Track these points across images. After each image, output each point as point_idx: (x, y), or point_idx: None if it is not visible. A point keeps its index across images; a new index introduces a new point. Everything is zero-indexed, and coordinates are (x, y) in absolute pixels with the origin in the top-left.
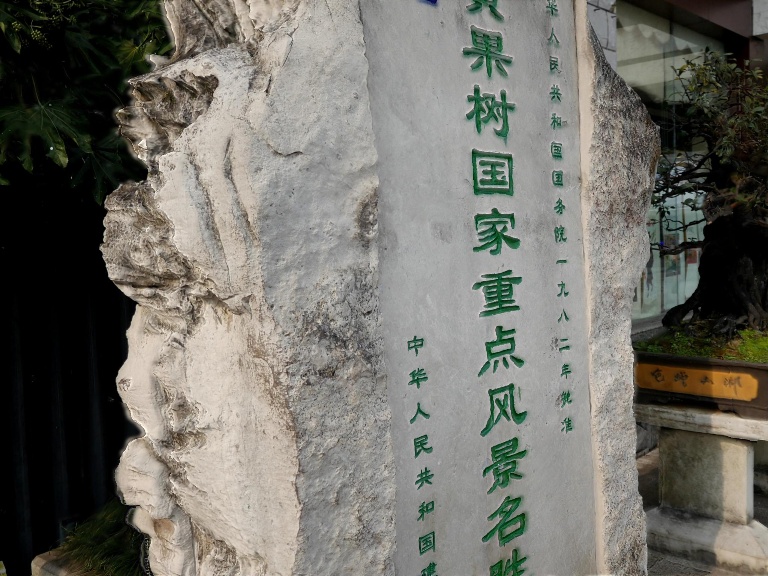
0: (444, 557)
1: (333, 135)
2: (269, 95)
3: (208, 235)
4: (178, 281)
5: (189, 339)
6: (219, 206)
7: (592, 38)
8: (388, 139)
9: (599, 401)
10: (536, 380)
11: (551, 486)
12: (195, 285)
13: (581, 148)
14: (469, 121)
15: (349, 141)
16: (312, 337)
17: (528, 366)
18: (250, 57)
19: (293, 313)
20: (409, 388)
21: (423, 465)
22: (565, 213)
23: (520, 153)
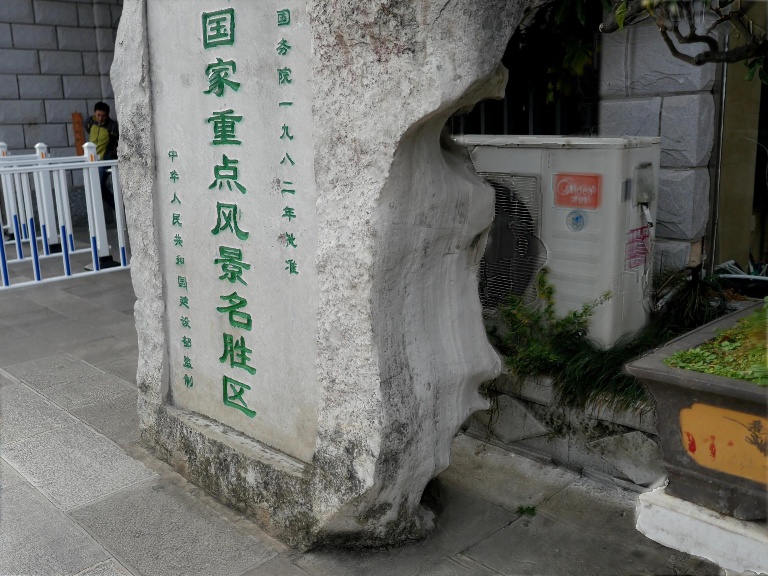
0: (193, 299)
1: None
2: None
3: None
4: None
5: None
6: None
7: None
8: (157, 22)
9: (319, 258)
10: (255, 209)
11: (276, 312)
12: None
13: None
14: None
15: None
16: None
17: (248, 194)
18: None
19: None
20: (171, 181)
21: (177, 232)
22: (292, 53)
23: (240, 4)
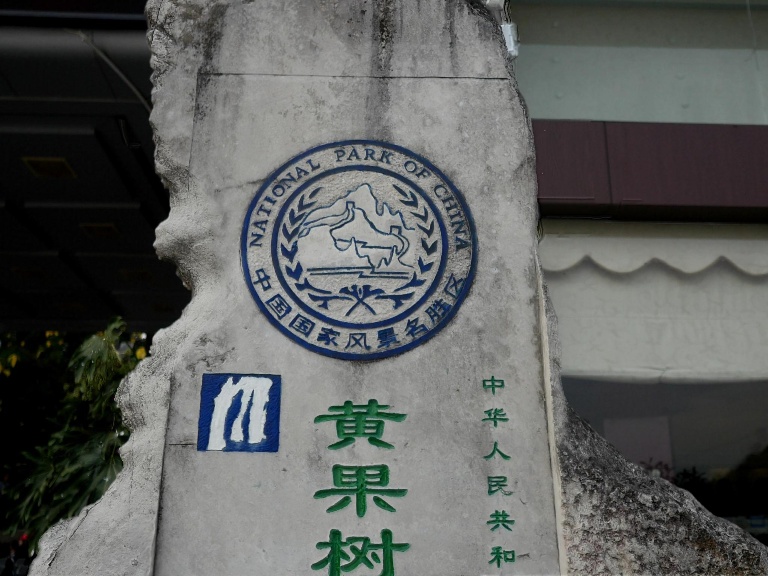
0: None
1: None
2: (50, 568)
3: None
4: None
5: None
6: None
7: (564, 446)
8: None
9: None
10: None
11: None
12: None
13: None
14: (317, 572)
15: None
16: None
17: None
18: None
19: None
20: None
21: None
22: None
23: None
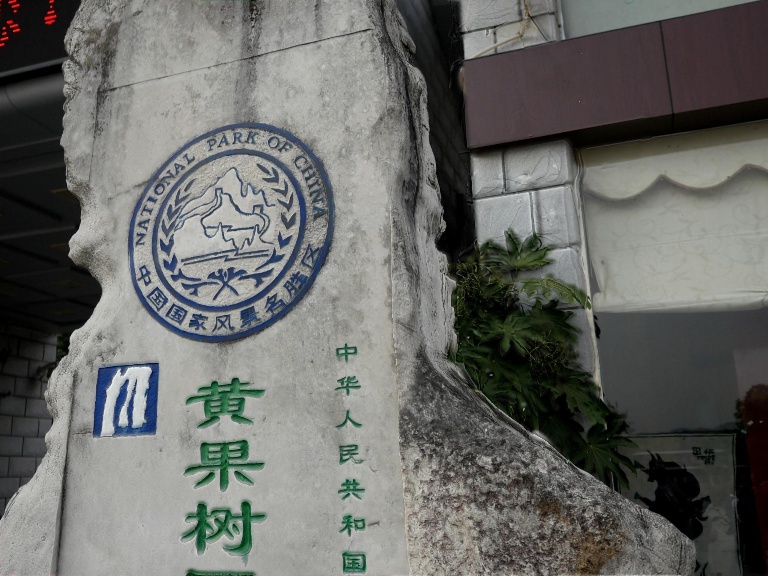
0: None
1: (18, 574)
2: None
3: None
4: None
5: None
6: None
7: (407, 410)
8: (80, 571)
9: None
10: None
11: None
12: None
13: None
14: (186, 544)
15: None
16: None
17: None
18: None
19: None
20: None
21: None
22: None
23: (270, 573)
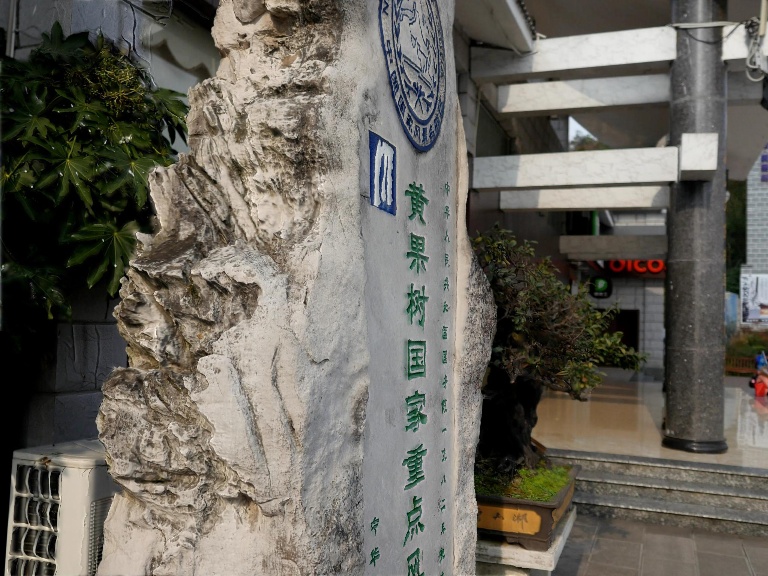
0: None
1: (346, 341)
2: (307, 306)
3: (253, 440)
4: (188, 477)
5: (201, 538)
6: (263, 412)
7: (469, 239)
8: None
9: (460, 552)
10: (430, 541)
11: None
12: (220, 485)
13: (456, 329)
14: (408, 315)
15: (354, 345)
16: (331, 535)
17: (427, 529)
18: (275, 263)
19: (318, 513)
20: (369, 568)
21: None
22: (447, 387)
23: (430, 339)
